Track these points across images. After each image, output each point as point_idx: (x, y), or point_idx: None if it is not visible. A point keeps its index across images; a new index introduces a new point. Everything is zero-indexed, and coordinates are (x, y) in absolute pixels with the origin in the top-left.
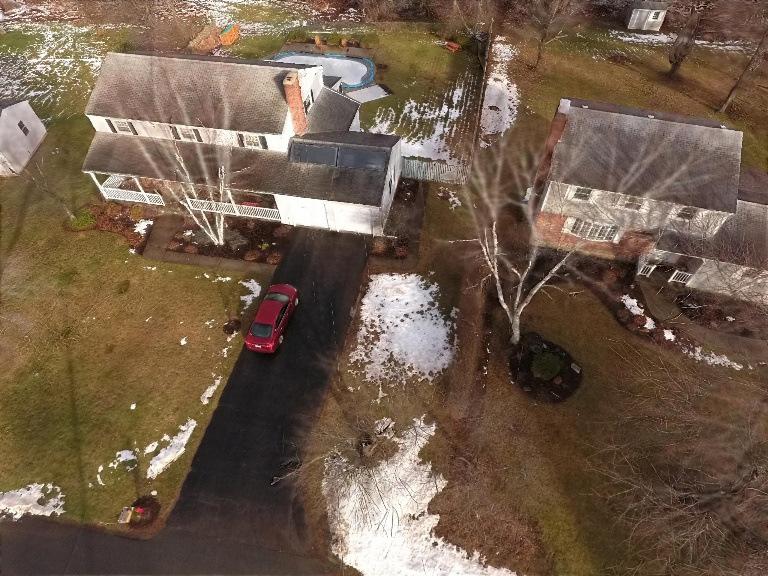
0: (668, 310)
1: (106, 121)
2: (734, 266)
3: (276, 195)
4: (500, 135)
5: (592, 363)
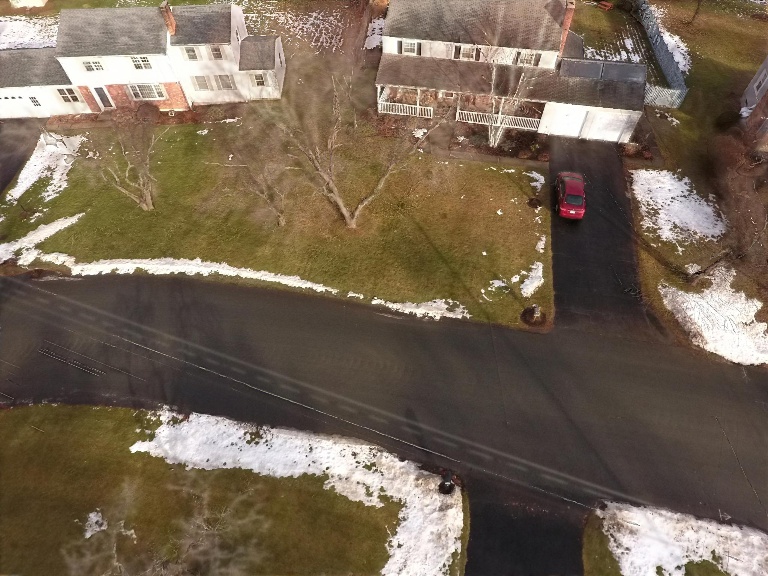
0: None
1: (397, 42)
2: None
3: (551, 103)
4: (686, 73)
5: None
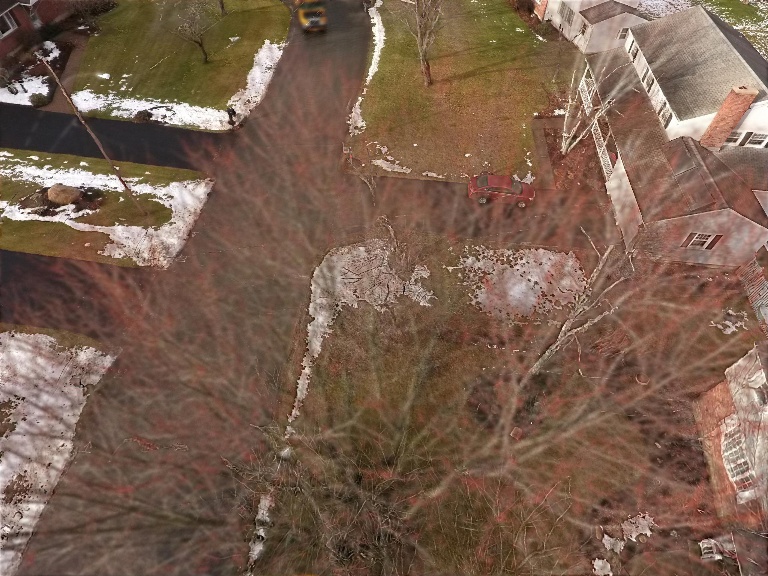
0: None
1: None
2: None
3: (618, 153)
4: None
5: (529, 456)
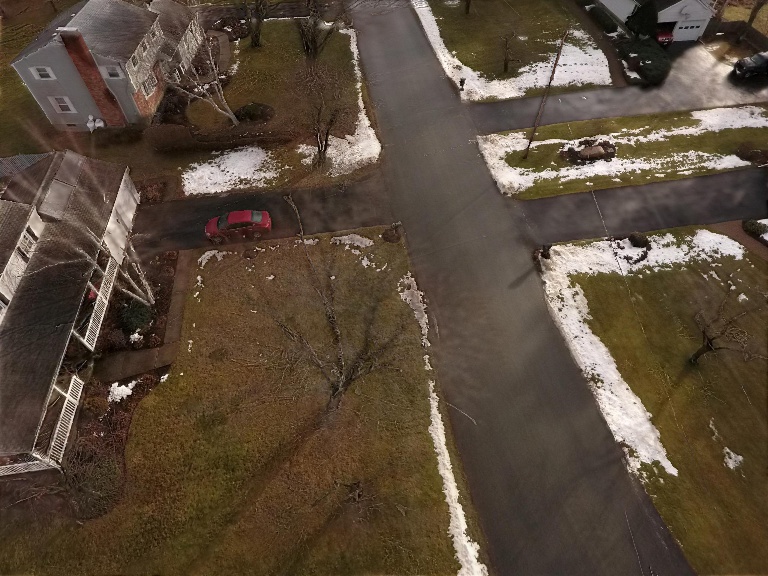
0: (204, 78)
1: None
2: (182, 40)
3: (106, 232)
4: None
5: (246, 101)
